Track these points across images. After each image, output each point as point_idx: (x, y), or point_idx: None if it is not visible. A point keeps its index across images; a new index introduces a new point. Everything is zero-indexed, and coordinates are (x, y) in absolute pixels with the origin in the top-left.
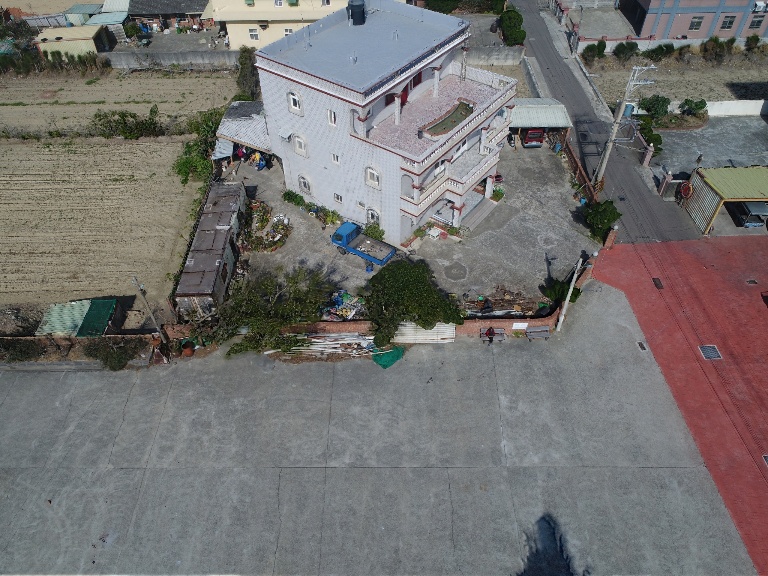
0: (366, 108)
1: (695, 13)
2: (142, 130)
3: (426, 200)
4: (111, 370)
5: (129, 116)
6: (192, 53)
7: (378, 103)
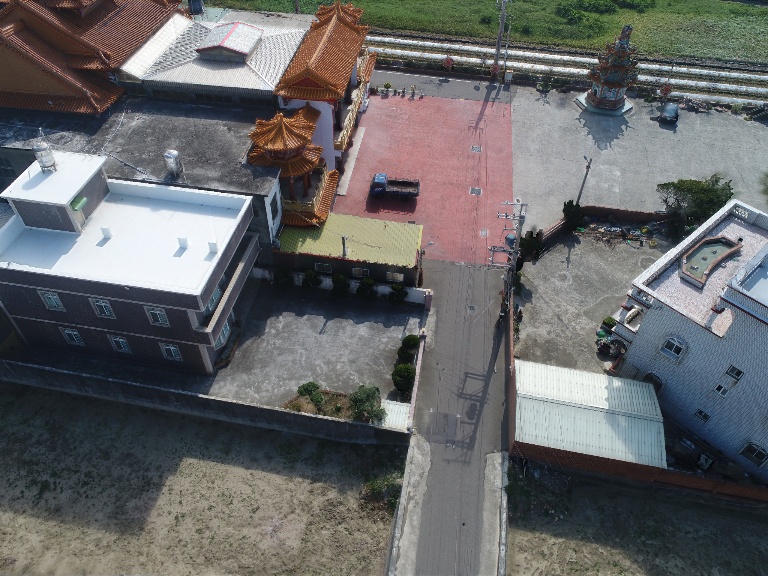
0: None
1: None
2: None
3: None
4: None
5: None
6: None
7: None
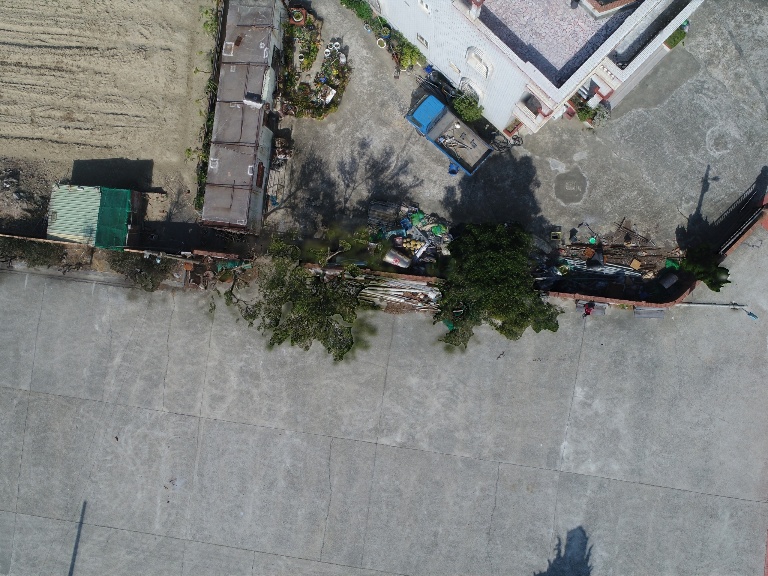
0: None
1: None
2: None
3: None
4: (144, 289)
5: None
6: None
7: None
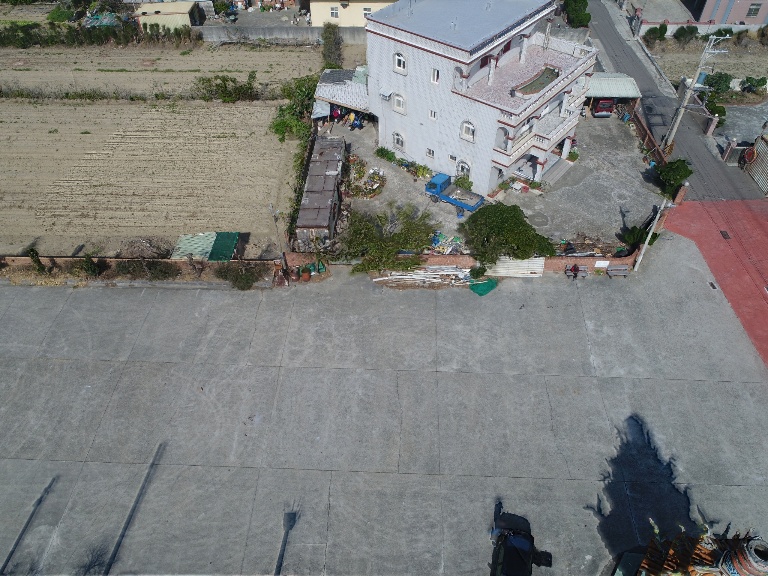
0: (470, 66)
1: (754, 0)
2: (240, 94)
3: (516, 153)
4: (239, 290)
5: (230, 81)
6: (278, 28)
7: (475, 65)
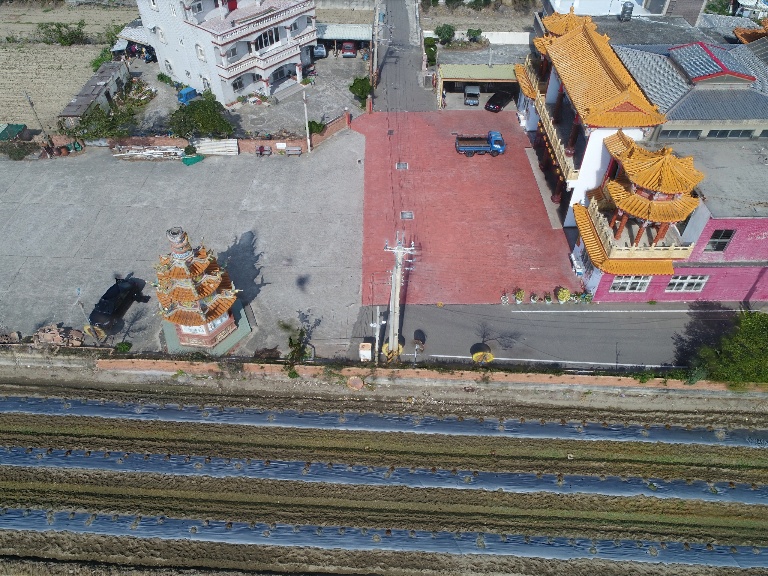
0: (189, 0)
1: None
2: (73, 38)
3: (236, 69)
4: (13, 160)
5: (63, 27)
6: None
7: (208, 4)
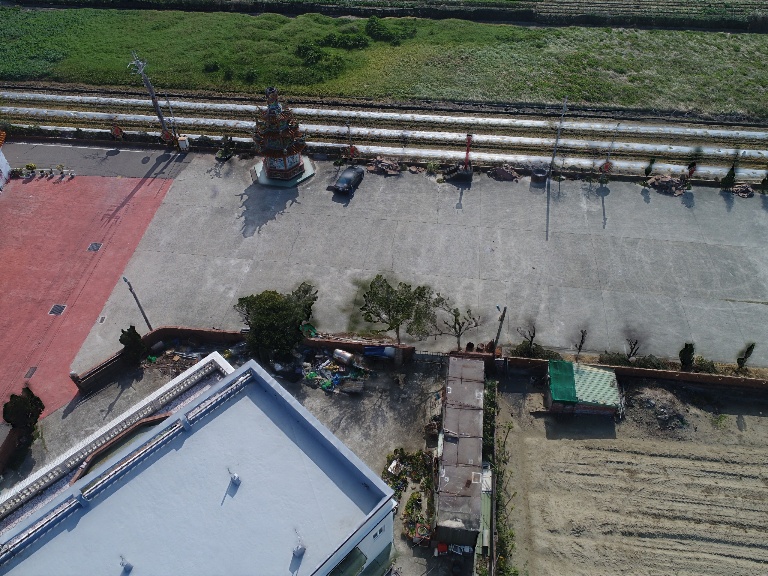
0: None
1: None
2: None
3: None
4: None
5: None
6: None
7: None
